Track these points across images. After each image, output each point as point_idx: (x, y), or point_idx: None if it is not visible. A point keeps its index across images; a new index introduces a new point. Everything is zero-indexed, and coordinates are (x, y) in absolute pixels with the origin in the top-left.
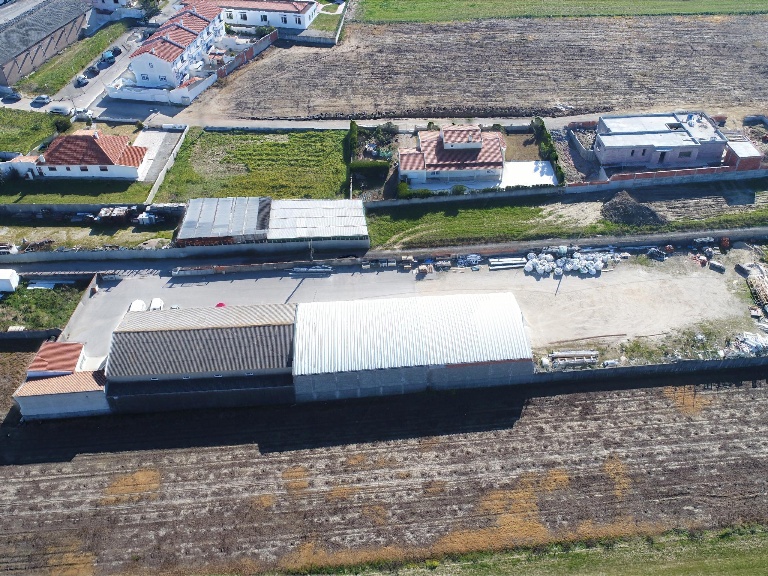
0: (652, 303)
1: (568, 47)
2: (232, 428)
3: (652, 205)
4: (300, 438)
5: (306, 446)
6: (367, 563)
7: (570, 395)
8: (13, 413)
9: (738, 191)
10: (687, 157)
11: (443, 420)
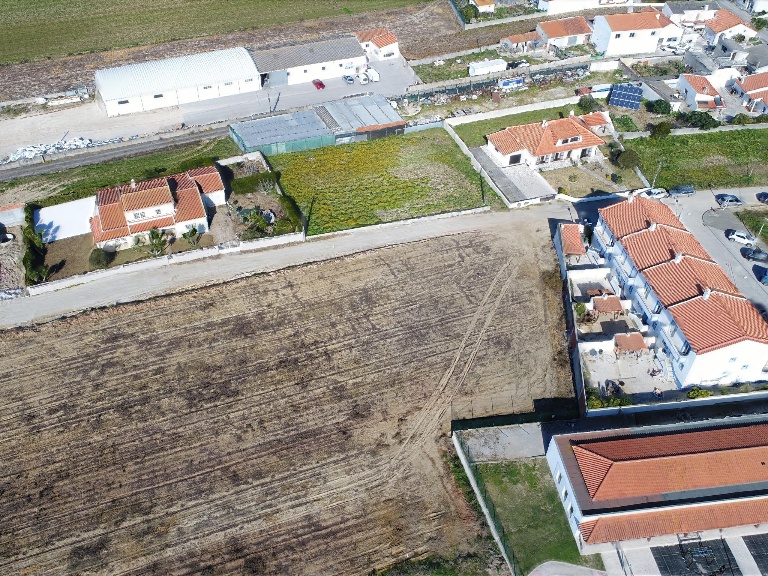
0: None
1: None
2: None
3: None
4: None
5: None
6: None
7: None
8: None
9: None
10: None
11: None
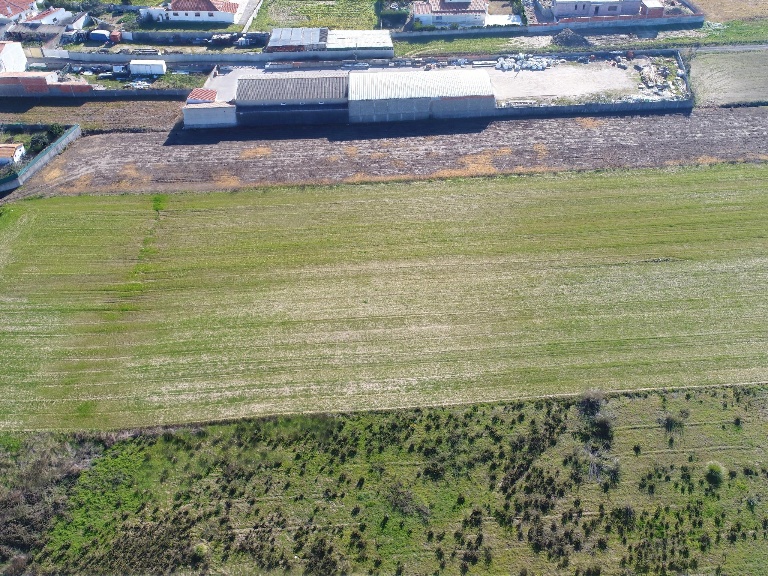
0: (576, 82)
1: None
2: (311, 133)
3: (586, 38)
4: (353, 136)
5: (356, 139)
6: (393, 180)
7: (518, 121)
8: (177, 126)
9: (647, 31)
10: (614, 11)
11: (439, 130)
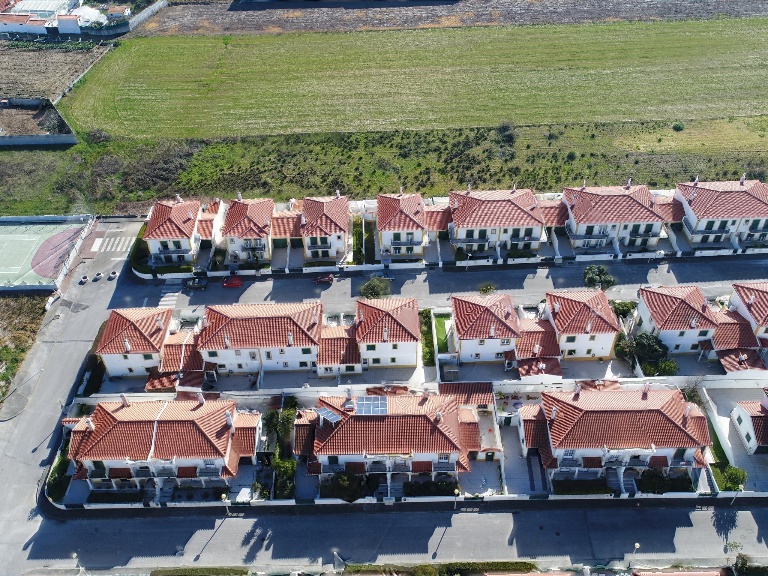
0: None
1: None
2: (332, 5)
3: None
4: None
5: (364, 8)
6: None
7: None
8: (236, 1)
9: None
10: None
11: (424, 3)
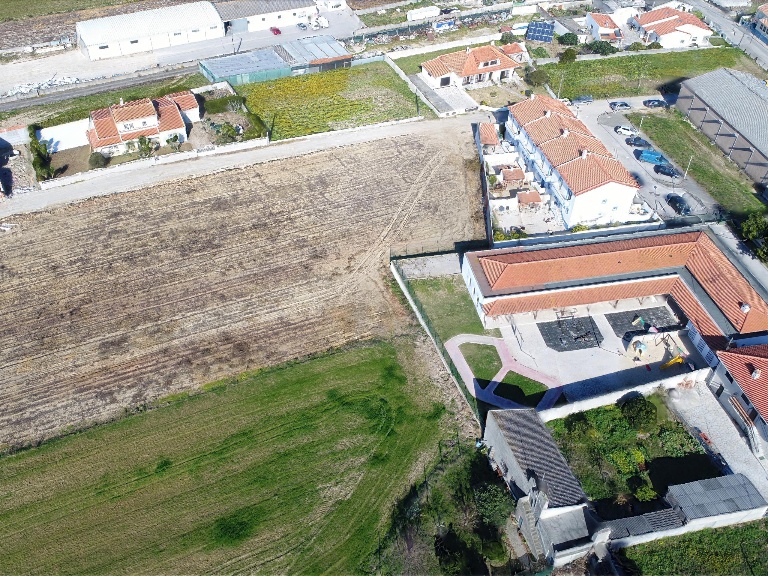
0: None
1: None
2: None
3: None
4: None
5: None
6: None
7: None
8: None
9: None
10: None
11: None
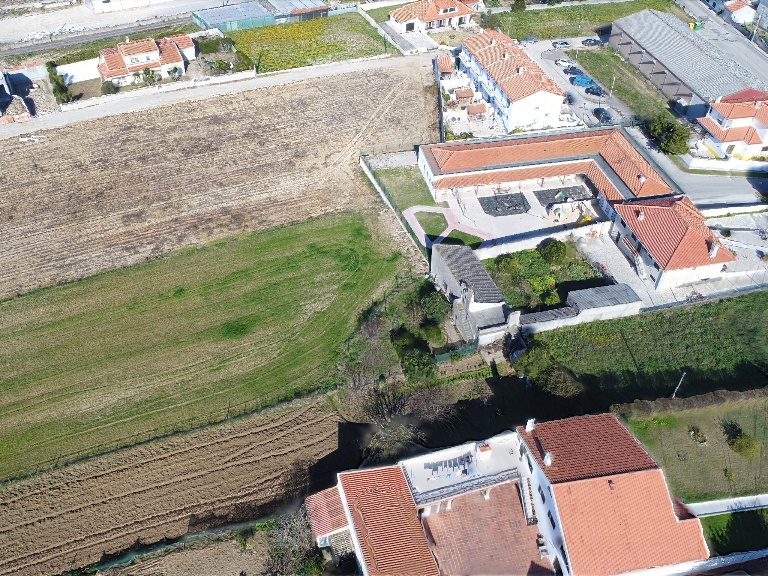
0: (3, 29)
1: (2, 229)
2: None
3: None
4: None
5: None
6: None
7: None
8: None
9: None
10: None
11: None
